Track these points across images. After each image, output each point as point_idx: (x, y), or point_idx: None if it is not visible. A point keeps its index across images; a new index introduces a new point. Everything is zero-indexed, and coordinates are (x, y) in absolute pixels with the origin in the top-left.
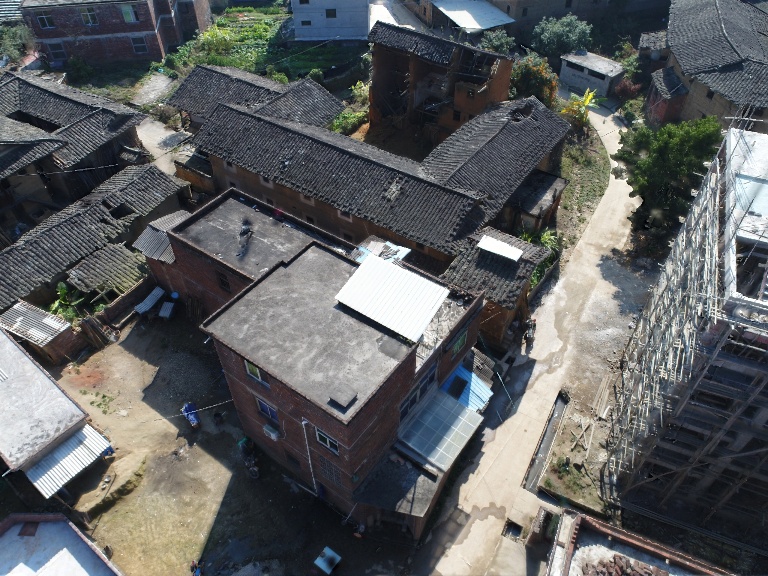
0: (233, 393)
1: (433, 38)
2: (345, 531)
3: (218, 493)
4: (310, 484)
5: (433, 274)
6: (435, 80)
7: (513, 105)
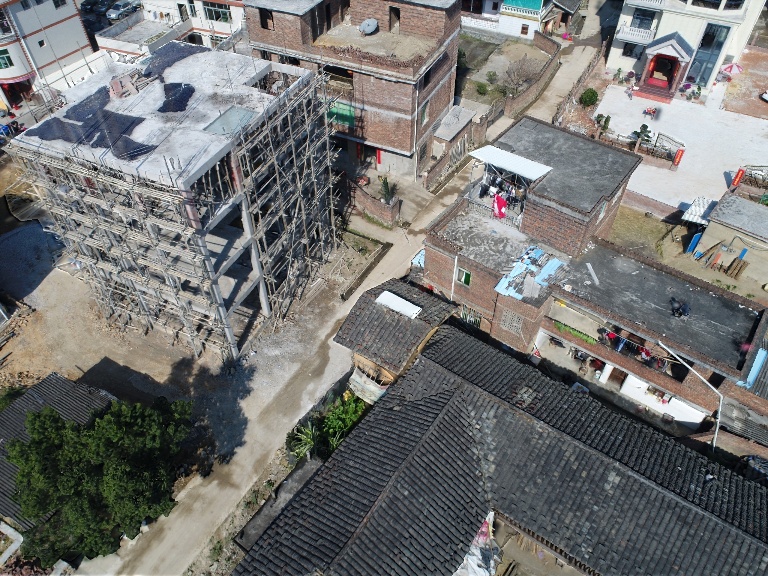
0: None
1: None
2: None
3: None
4: None
5: None
6: None
7: None
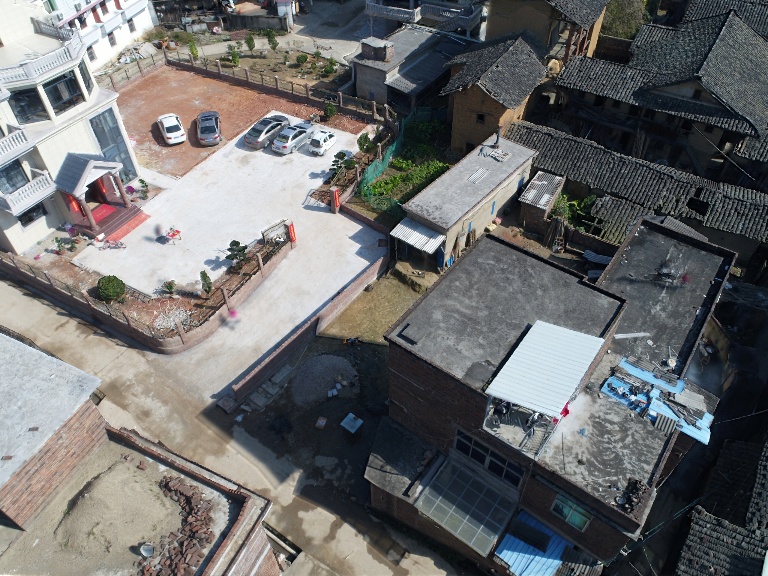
0: None
1: None
2: None
3: None
4: None
5: (730, 522)
6: None
7: None
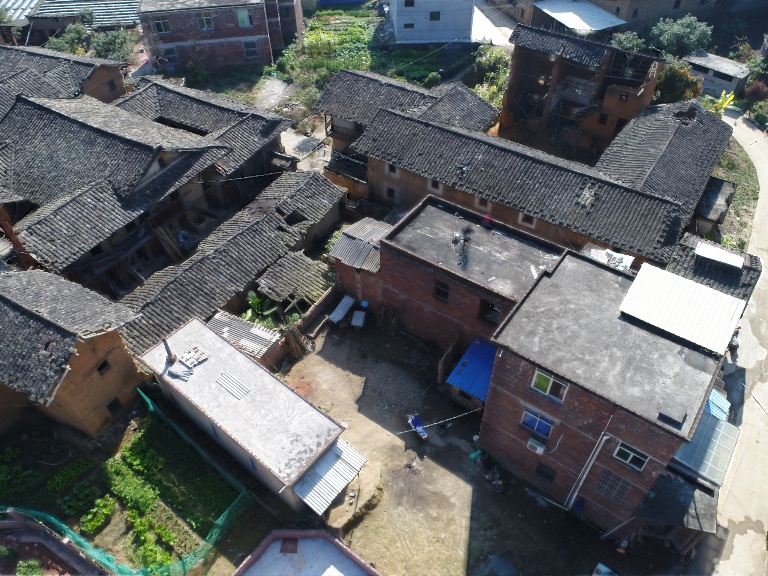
0: (489, 406)
1: (582, 41)
2: (606, 546)
3: (464, 507)
4: (558, 498)
5: None
6: (573, 83)
7: (674, 108)
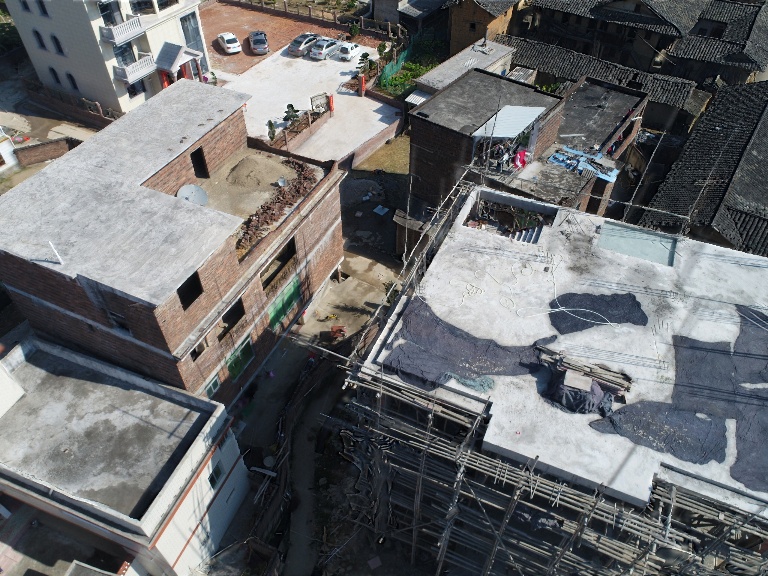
0: None
1: None
2: None
3: None
4: None
5: None
6: None
7: None
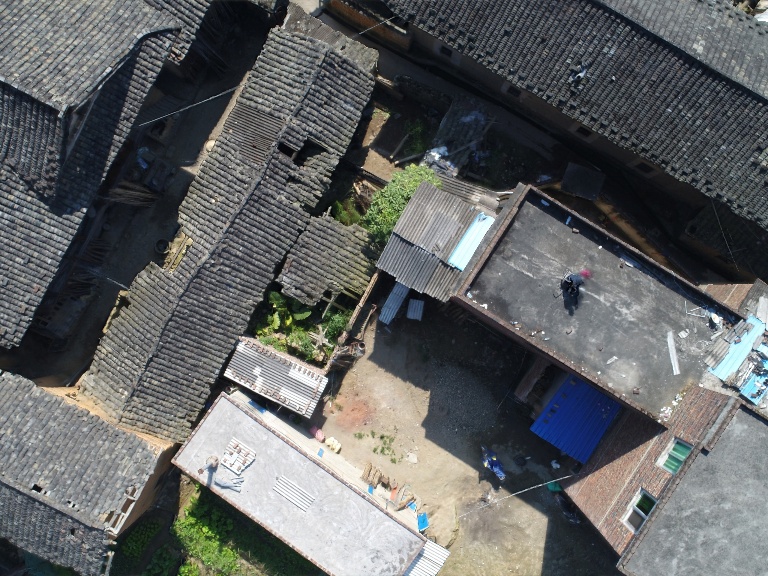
0: None
1: None
2: None
3: (538, 539)
4: None
5: None
6: None
7: None
